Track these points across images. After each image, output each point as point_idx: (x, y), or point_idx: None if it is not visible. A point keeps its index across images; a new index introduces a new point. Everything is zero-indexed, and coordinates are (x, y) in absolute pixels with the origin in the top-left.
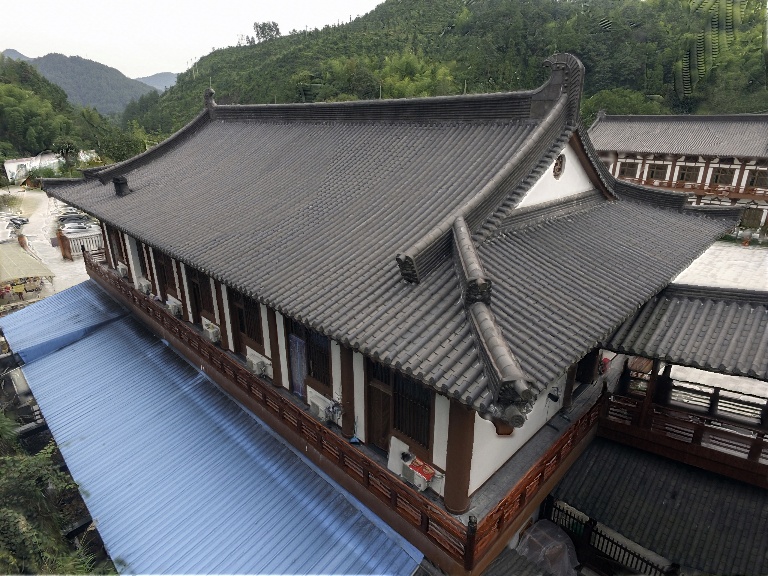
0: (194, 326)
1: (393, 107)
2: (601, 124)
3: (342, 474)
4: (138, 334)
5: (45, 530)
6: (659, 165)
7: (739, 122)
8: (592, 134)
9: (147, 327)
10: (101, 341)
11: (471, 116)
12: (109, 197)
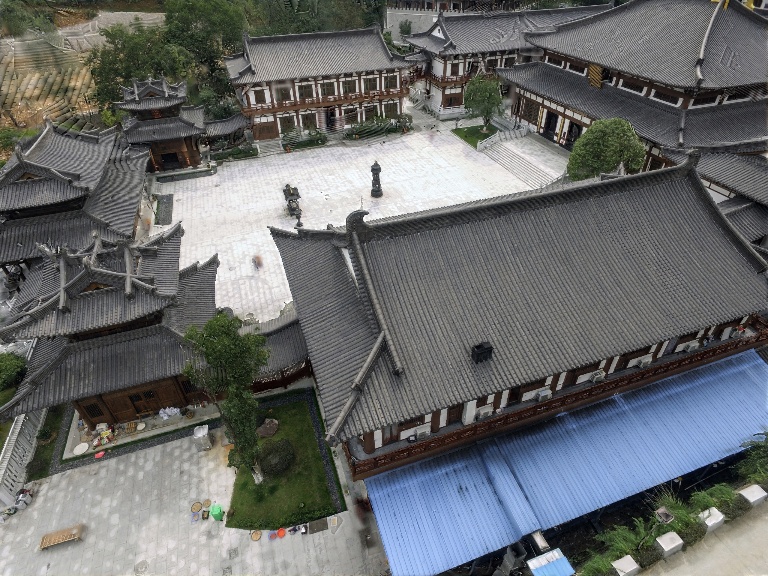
0: (565, 389)
1: (606, 186)
2: (251, 48)
3: (724, 354)
4: (536, 433)
5: (688, 505)
6: (327, 83)
7: (354, 36)
8: (254, 61)
9: (530, 425)
10: (530, 463)
11: (651, 182)
12: (474, 370)
